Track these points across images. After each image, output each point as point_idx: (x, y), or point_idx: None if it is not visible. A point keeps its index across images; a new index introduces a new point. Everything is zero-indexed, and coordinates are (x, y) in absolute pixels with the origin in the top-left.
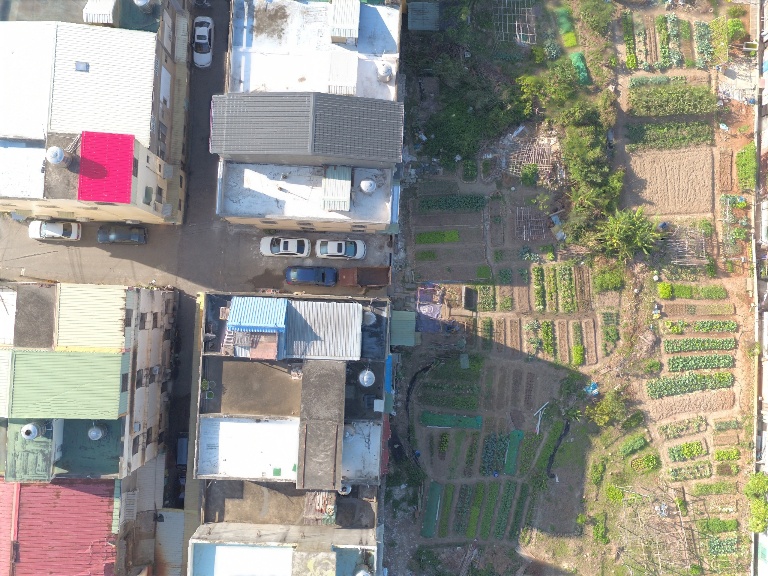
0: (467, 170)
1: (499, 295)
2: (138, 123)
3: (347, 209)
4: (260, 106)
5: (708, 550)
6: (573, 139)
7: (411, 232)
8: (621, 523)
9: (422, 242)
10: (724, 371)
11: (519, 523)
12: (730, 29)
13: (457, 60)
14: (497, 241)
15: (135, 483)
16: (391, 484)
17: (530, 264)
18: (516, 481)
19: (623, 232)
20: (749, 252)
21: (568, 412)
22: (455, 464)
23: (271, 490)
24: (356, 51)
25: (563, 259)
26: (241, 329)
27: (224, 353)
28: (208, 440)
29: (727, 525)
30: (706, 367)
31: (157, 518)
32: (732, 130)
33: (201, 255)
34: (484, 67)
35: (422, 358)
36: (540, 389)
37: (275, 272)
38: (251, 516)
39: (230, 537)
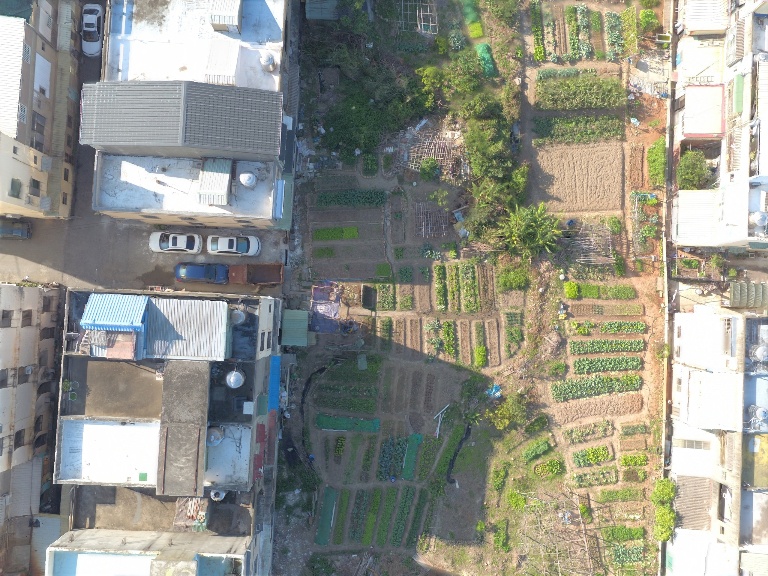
0: (367, 164)
1: (399, 294)
2: (4, 112)
3: (224, 203)
4: (131, 95)
5: (613, 559)
6: (474, 133)
7: (308, 228)
8: (523, 530)
9: (319, 239)
10: (632, 374)
11: (417, 530)
12: (642, 20)
13: (355, 50)
14: (398, 238)
15: (8, 487)
16: (284, 489)
17: (432, 262)
18: (415, 486)
19: (524, 229)
20: (660, 251)
21: (467, 415)
22: (351, 468)
23: (144, 495)
24: (238, 39)
25: (466, 257)
26: (96, 327)
27: (81, 352)
28: (71, 443)
29: (633, 533)
30: (613, 369)
31: (33, 523)
32: (643, 125)
33: (88, 251)
34: (386, 58)
35: (318, 359)
36: (440, 391)
37: (166, 269)
38: (123, 522)
39: (92, 545)
